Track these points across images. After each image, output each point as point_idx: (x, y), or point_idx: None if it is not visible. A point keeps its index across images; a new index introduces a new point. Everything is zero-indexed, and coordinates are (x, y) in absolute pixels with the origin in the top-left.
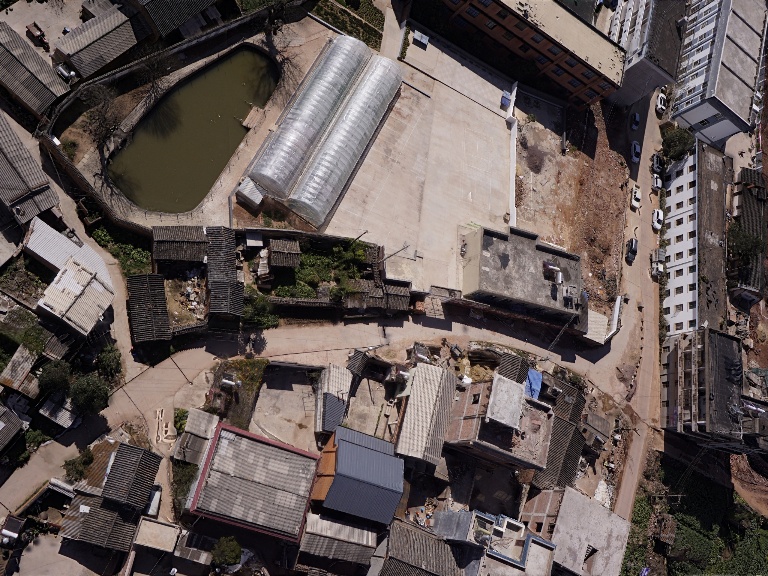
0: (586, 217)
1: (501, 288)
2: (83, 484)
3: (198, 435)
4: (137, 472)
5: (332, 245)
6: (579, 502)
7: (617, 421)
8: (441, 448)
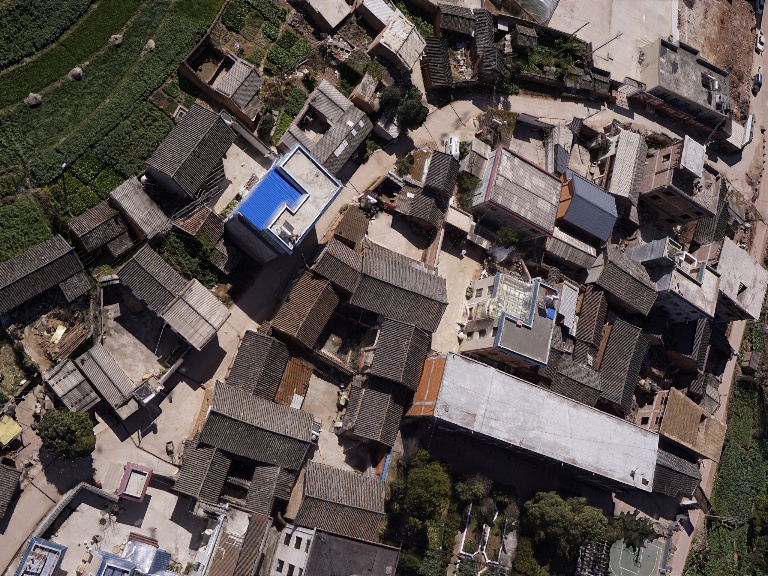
0: (726, 49)
1: (673, 88)
2: (409, 177)
3: (481, 155)
4: (448, 171)
5: (553, 39)
6: (734, 250)
7: (747, 213)
8: (638, 195)
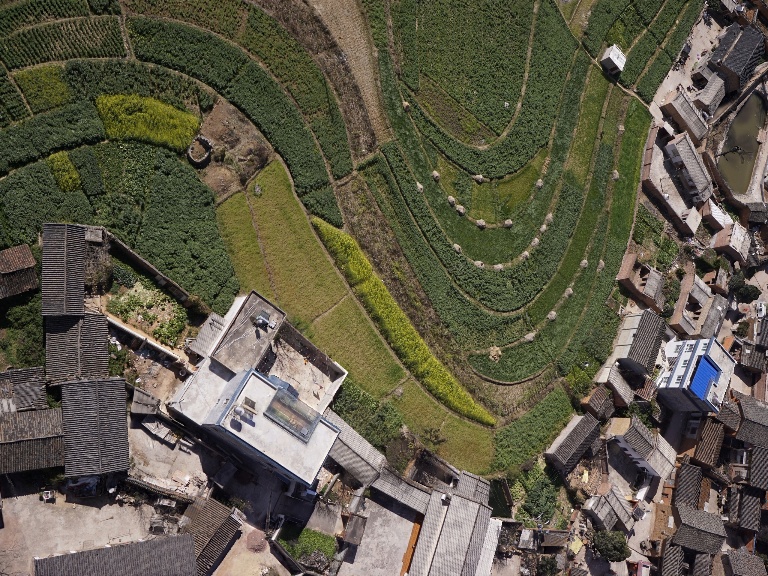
0: None
1: None
2: (747, 339)
3: None
4: None
5: None
6: None
7: None
8: None
